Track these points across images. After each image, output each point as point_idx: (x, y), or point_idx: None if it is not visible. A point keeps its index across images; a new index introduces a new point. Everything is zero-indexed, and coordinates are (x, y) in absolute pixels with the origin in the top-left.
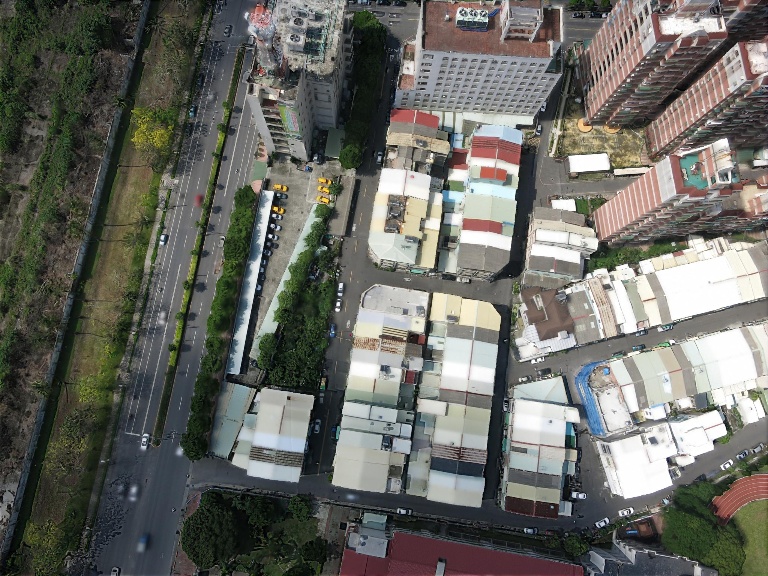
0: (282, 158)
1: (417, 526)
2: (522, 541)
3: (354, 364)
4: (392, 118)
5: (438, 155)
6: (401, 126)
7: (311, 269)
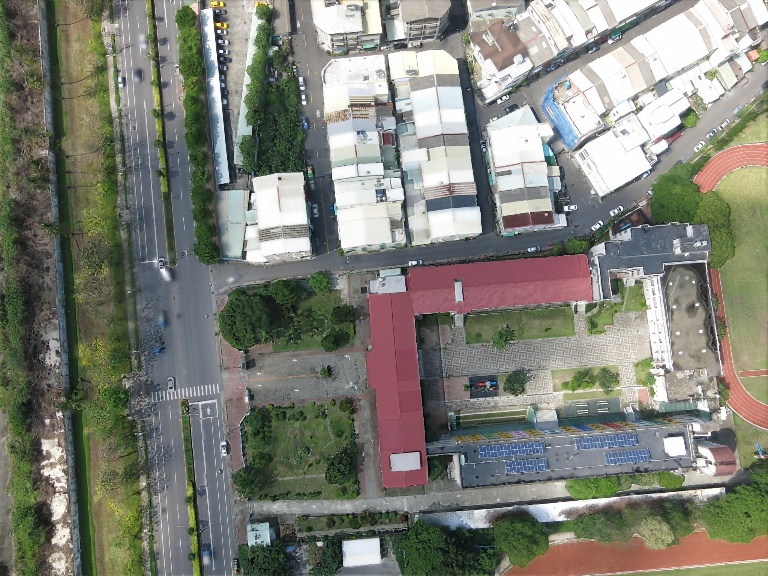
0: None
1: None
2: None
3: (332, 138)
4: None
5: None
6: None
7: (269, 72)
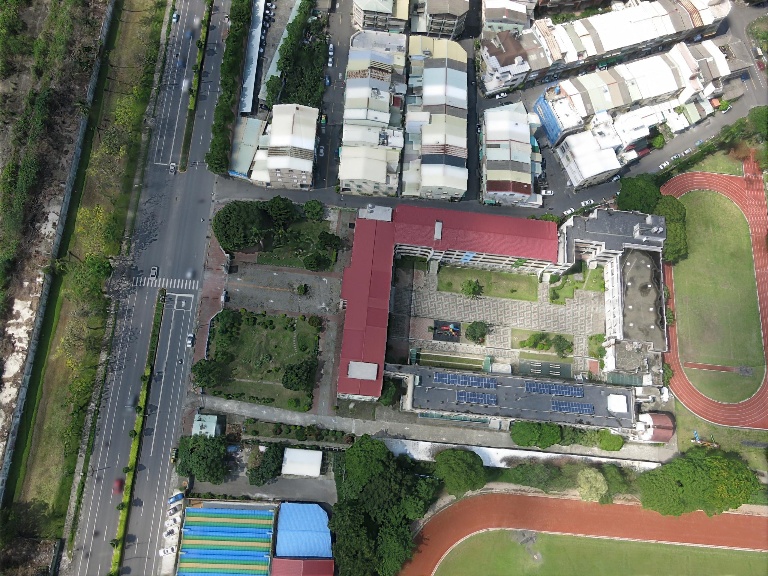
0: None
1: None
2: None
3: (349, 90)
4: None
5: None
6: None
7: (304, 35)
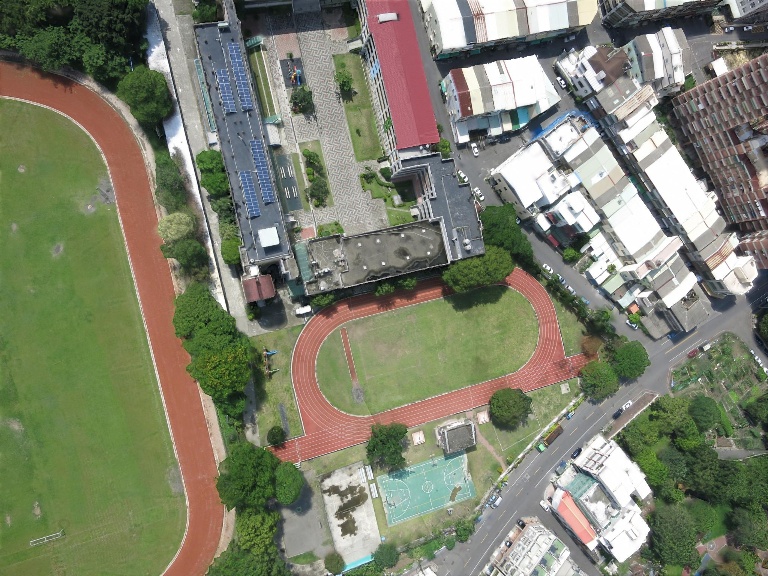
0: None
1: None
2: None
3: None
4: None
5: None
6: None
7: None
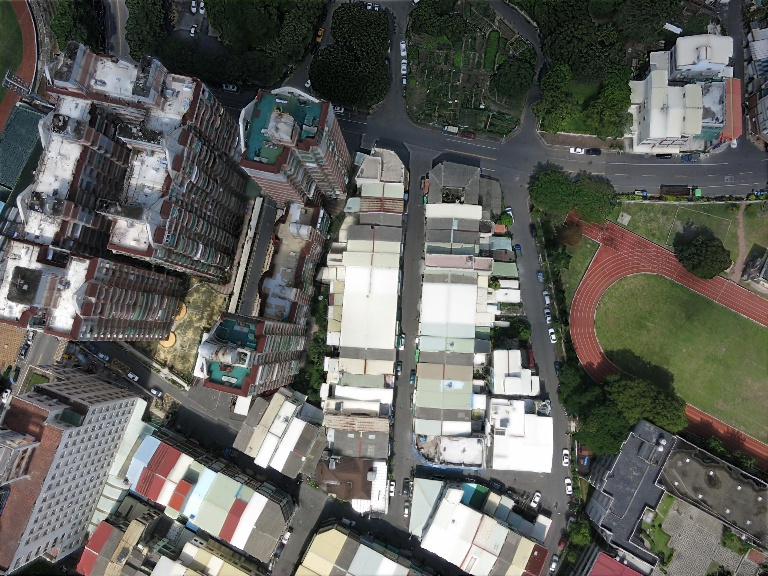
0: None
1: None
2: (561, 575)
3: None
4: (86, 574)
5: (143, 534)
6: (97, 569)
7: None
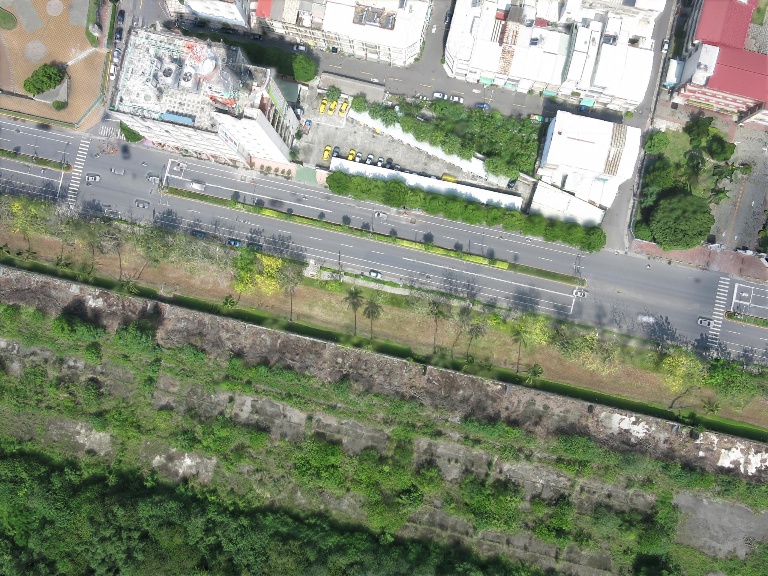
0: (294, 150)
1: (679, 35)
2: None
3: (526, 74)
4: (266, 16)
5: None
6: (276, 6)
7: None
